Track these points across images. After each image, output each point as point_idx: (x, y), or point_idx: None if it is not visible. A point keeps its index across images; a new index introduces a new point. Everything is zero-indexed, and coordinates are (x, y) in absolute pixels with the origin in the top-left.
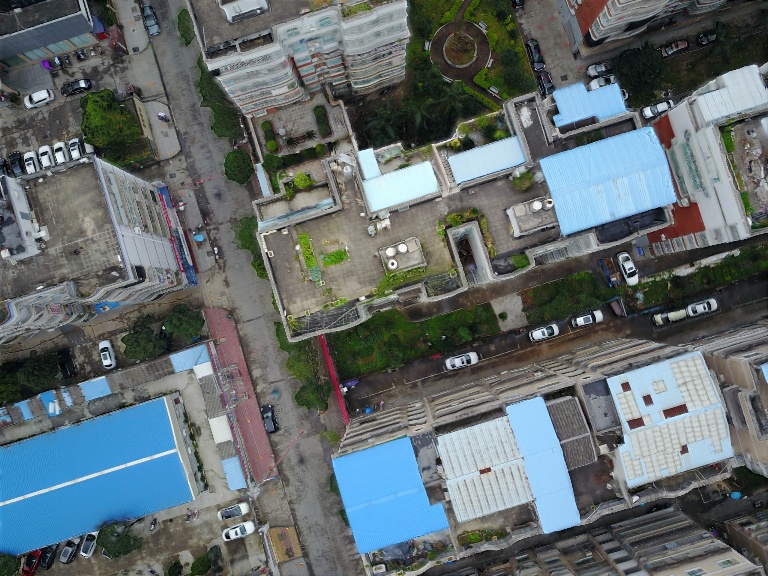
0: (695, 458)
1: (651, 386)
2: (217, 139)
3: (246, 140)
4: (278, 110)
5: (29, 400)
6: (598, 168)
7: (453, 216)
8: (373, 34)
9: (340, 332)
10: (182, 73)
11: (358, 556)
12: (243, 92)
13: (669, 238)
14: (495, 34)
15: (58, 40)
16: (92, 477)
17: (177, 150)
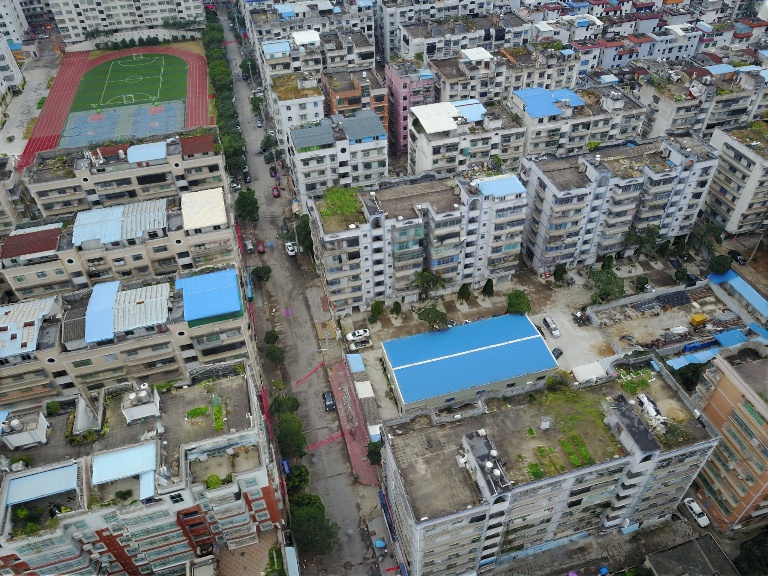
0: (3, 310)
1: (7, 345)
2: None
3: None
4: None
5: None
6: None
7: (90, 437)
8: None
9: None
10: None
11: (277, 324)
12: None
13: None
14: None
15: None
16: (458, 354)
17: None
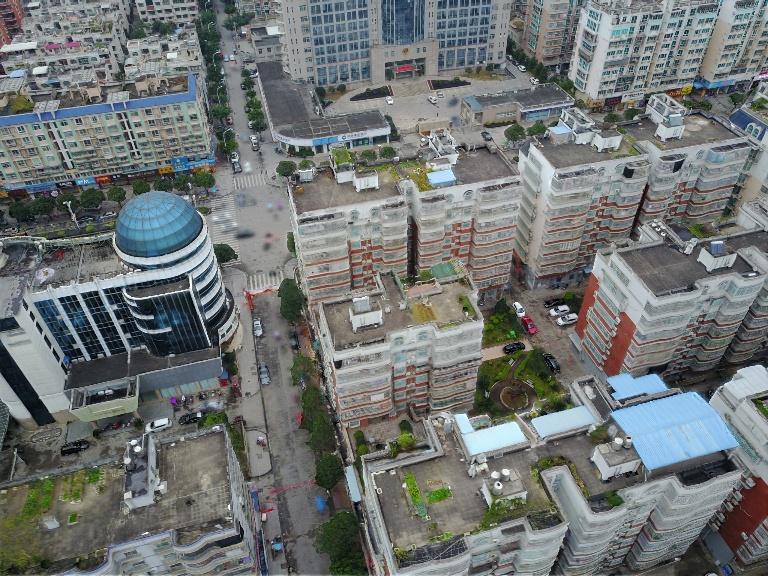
0: None
1: None
2: (305, 461)
3: (336, 452)
4: (369, 424)
5: None
6: (662, 417)
7: (544, 461)
8: (457, 349)
9: None
10: (282, 411)
11: None
12: (350, 393)
13: (750, 533)
14: (541, 387)
15: (191, 381)
16: None
17: (268, 469)
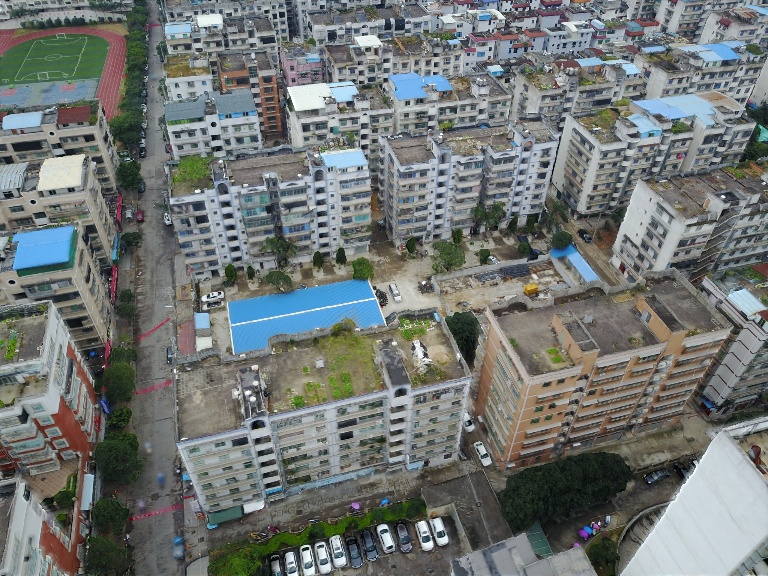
0: None
1: None
2: None
3: None
4: None
5: None
6: None
7: None
8: None
9: None
10: None
11: (140, 286)
12: None
13: None
14: None
15: None
16: (295, 313)
17: (190, 567)
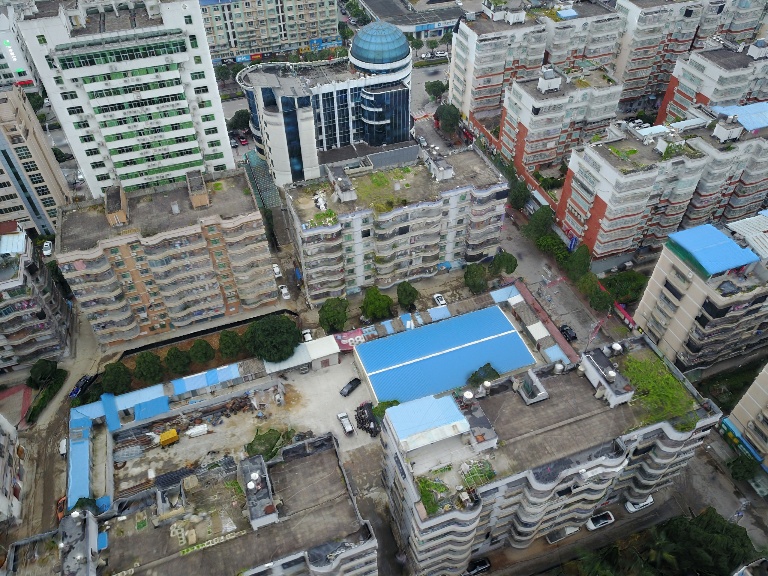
0: None
1: None
2: None
3: None
4: (539, 170)
5: (392, 320)
6: None
7: None
8: (604, 108)
9: (601, 283)
10: None
11: None
12: (537, 139)
13: None
14: None
15: None
16: (455, 349)
17: None
